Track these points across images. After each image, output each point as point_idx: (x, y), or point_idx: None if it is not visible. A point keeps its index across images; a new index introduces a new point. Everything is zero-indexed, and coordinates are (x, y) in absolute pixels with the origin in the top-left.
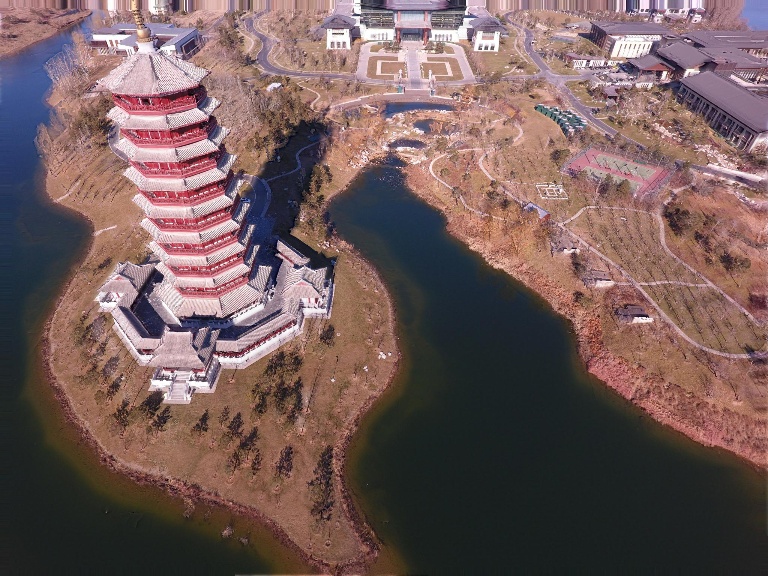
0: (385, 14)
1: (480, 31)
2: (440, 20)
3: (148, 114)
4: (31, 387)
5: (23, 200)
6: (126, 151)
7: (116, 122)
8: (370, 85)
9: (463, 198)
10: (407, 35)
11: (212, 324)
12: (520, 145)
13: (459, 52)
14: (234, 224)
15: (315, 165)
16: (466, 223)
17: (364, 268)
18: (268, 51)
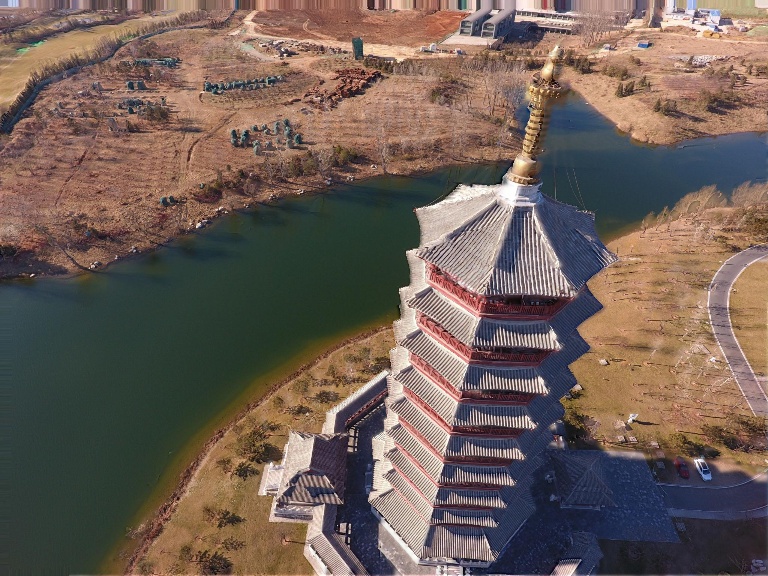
0: None
1: None
2: None
3: None
4: (320, 344)
5: None
6: None
7: None
8: None
9: None
10: None
11: None
12: None
13: None
14: (439, 470)
15: None
16: None
17: None
18: None
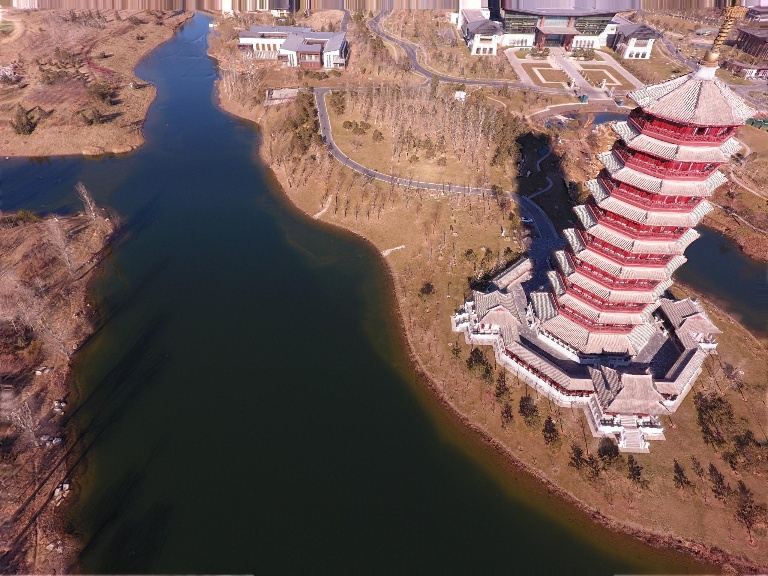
0: (529, 19)
1: (635, 38)
2: (583, 26)
3: (701, 145)
4: (445, 429)
5: (276, 215)
6: (634, 182)
7: (323, 132)
8: (547, 94)
9: (743, 219)
10: (547, 41)
11: (615, 361)
12: (760, 161)
13: (609, 59)
14: (680, 257)
15: (565, 181)
16: (766, 246)
17: (696, 296)
18: (414, 56)
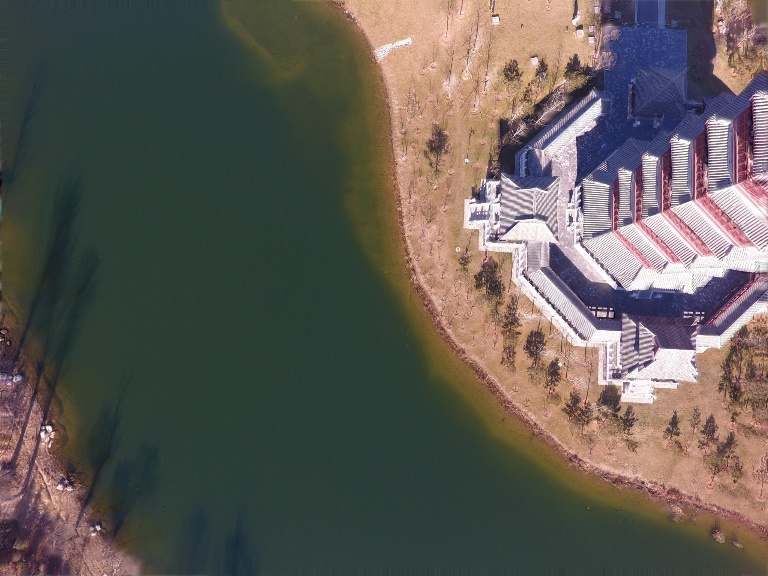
0: None
1: None
2: None
3: None
4: (438, 361)
5: None
6: None
7: None
8: None
9: None
10: None
11: None
12: None
13: None
14: None
15: None
16: None
17: None
18: None
